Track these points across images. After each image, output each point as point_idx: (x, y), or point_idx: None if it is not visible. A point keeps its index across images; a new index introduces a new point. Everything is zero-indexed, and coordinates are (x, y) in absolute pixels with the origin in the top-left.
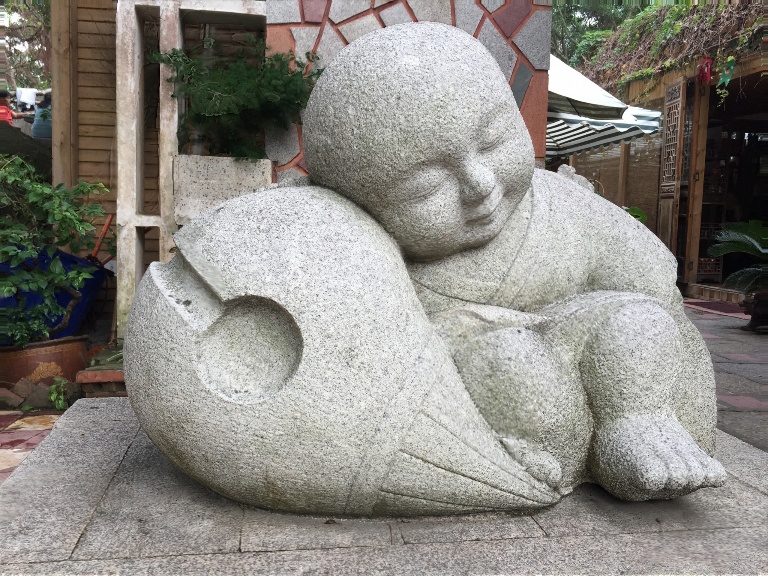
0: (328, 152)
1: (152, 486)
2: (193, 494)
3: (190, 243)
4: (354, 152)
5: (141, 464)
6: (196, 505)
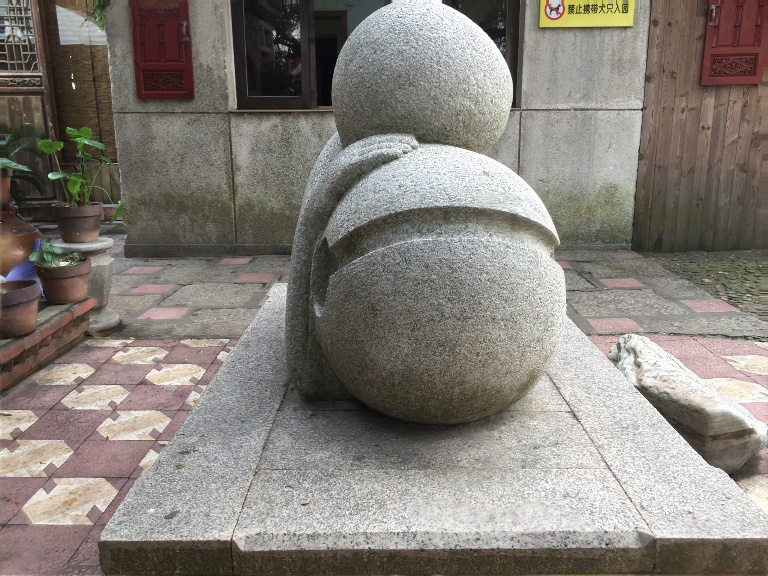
0: (471, 116)
1: (465, 449)
2: (480, 430)
3: (519, 207)
4: (492, 117)
5: (409, 459)
6: (502, 428)
